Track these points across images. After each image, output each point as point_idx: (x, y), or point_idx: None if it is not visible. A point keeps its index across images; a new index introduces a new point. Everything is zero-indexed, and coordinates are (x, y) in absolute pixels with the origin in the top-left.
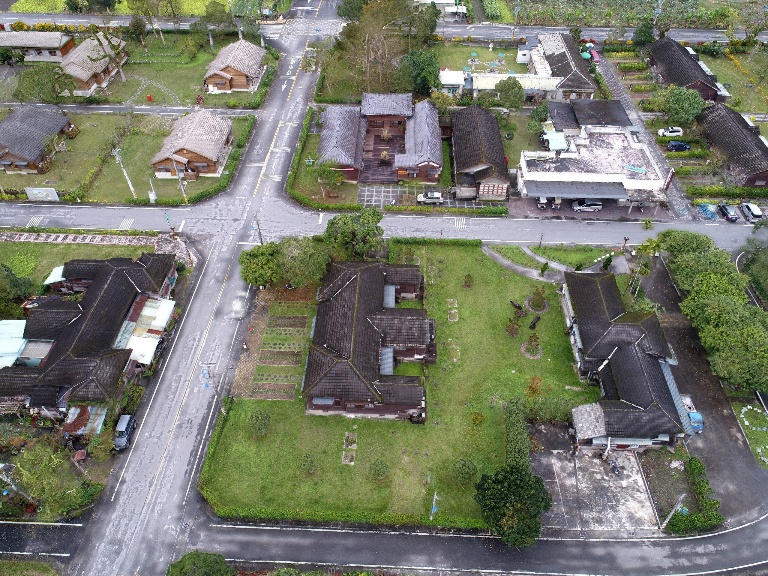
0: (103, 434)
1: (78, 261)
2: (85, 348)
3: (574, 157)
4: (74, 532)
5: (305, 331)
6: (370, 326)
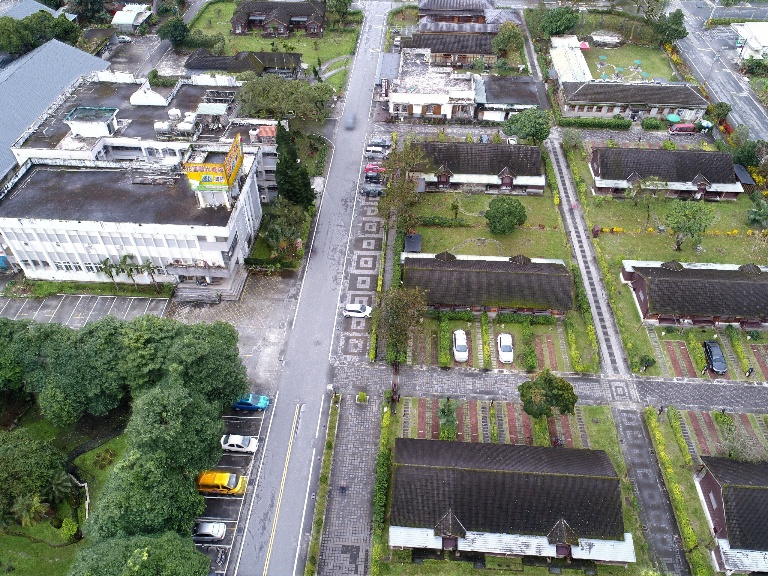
0: None
1: None
2: None
3: None
4: None
5: None
6: (274, 8)
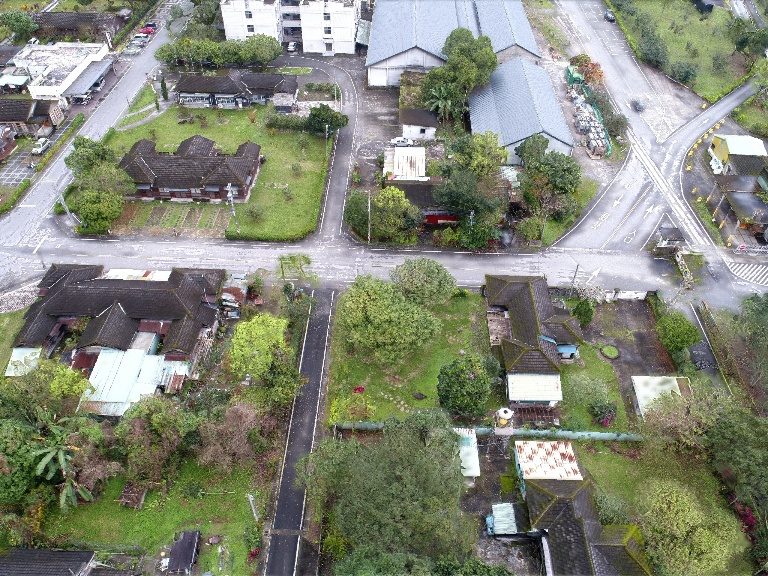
0: (250, 277)
1: (20, 336)
2: (167, 287)
3: (50, 71)
4: (318, 292)
5: (170, 207)
6: None
